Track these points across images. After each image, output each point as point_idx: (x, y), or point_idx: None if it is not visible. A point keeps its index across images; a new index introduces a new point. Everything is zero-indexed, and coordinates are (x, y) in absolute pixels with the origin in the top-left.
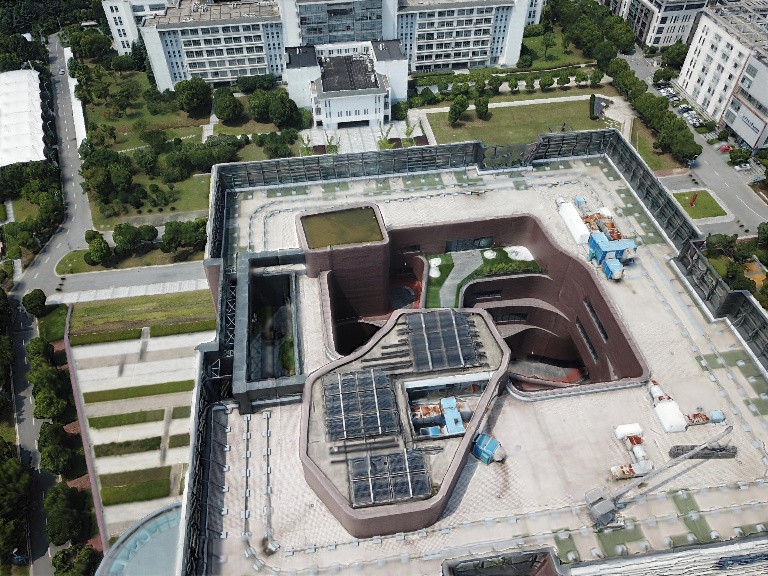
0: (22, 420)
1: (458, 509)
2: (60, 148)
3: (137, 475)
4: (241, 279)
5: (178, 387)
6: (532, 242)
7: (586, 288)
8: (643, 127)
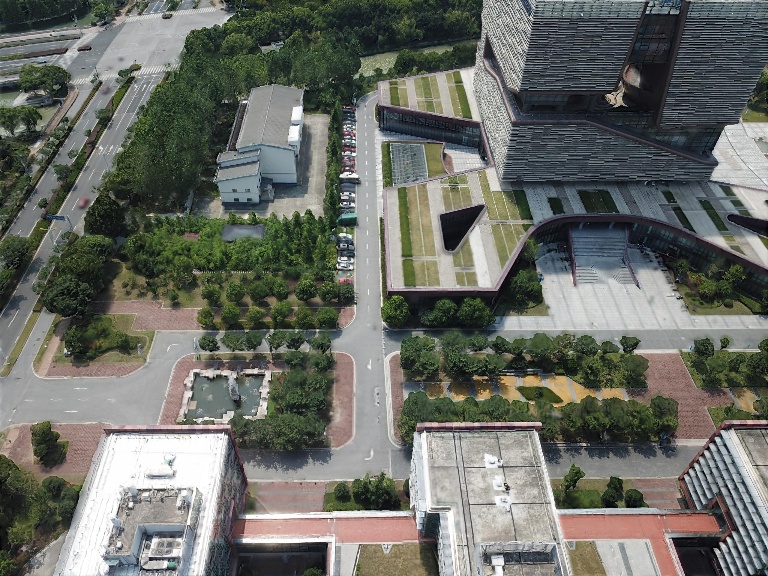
0: None
1: None
2: None
3: None
4: None
5: None
6: None
7: None
8: None
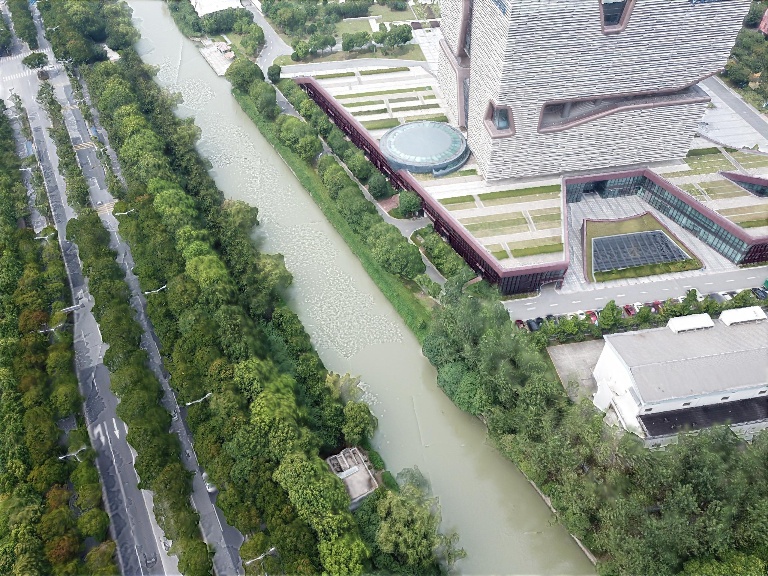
0: None
1: None
2: None
3: (380, 121)
4: None
5: (387, 92)
6: None
7: None
8: None
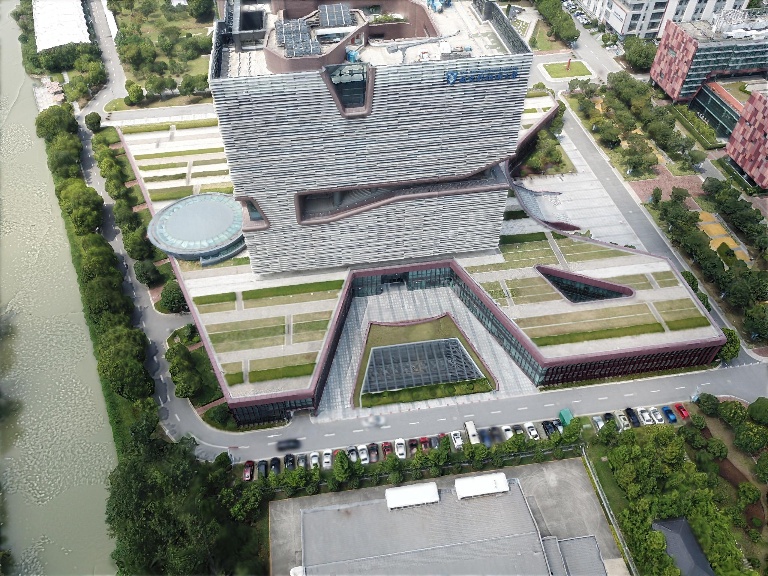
0: (91, 183)
1: (337, 74)
2: (99, 42)
3: (172, 189)
4: (236, 4)
5: (196, 152)
6: (402, 8)
7: (424, 19)
8: (544, 25)
